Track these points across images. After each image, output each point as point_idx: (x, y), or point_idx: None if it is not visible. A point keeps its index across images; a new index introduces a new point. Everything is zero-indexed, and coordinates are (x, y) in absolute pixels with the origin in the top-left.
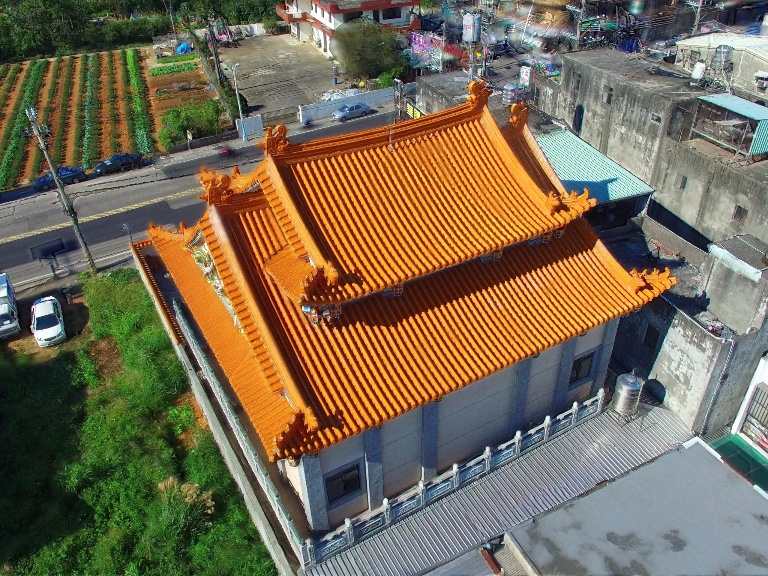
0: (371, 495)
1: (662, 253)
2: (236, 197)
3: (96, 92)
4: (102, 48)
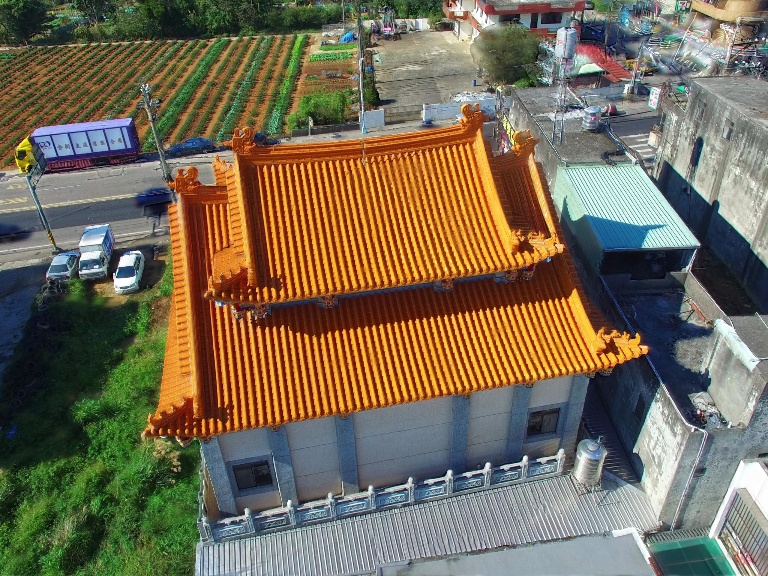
0: (282, 493)
1: (693, 317)
2: (203, 189)
3: (256, 72)
4: (279, 31)
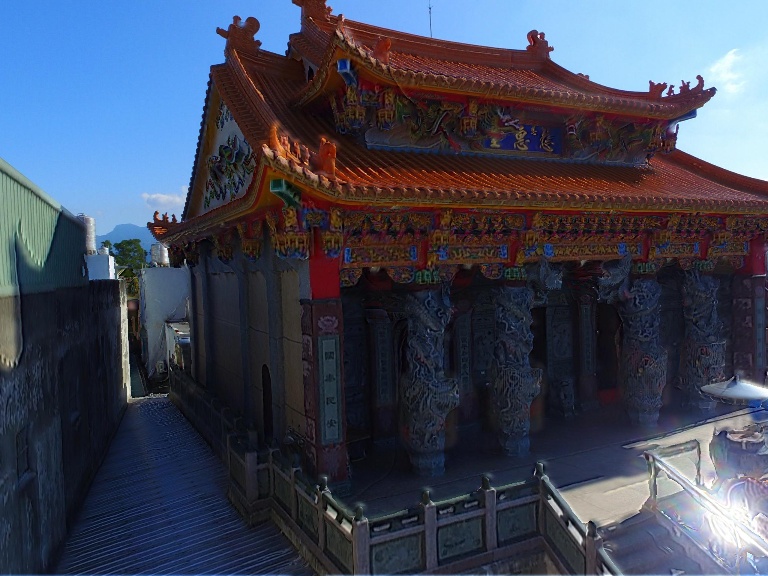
0: None
1: None
2: None
3: None
4: None
